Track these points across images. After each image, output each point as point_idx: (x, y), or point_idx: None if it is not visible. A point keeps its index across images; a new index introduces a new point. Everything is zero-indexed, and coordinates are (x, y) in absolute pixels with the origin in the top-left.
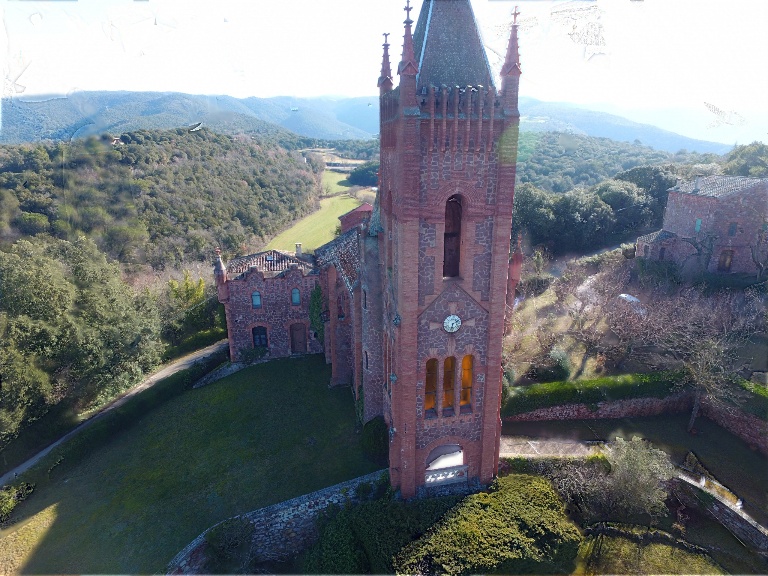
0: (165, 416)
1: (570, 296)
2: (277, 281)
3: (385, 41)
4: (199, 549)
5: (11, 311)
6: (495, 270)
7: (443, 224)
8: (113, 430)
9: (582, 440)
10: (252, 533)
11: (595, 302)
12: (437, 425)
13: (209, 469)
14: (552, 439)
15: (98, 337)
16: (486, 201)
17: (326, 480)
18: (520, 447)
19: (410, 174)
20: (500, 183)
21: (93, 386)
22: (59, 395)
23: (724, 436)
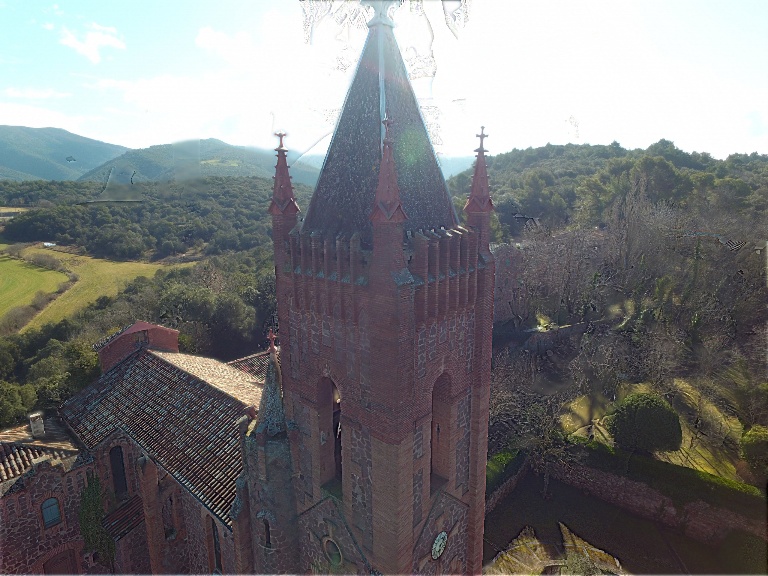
0: None
1: None
2: (8, 501)
3: (280, 145)
4: None
5: None
6: (478, 453)
7: (430, 420)
8: None
9: (489, 561)
10: None
11: None
12: None
13: None
14: None
15: None
16: (465, 371)
17: None
18: None
19: (404, 371)
20: (482, 346)
21: None
22: None
23: (565, 490)
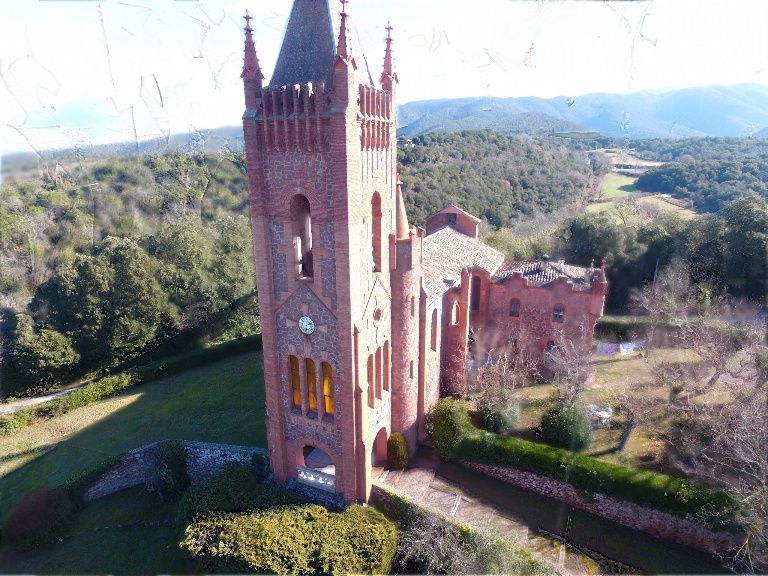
0: (240, 360)
1: (736, 359)
2: None
3: None
4: (151, 451)
5: (170, 260)
6: (337, 278)
7: (290, 223)
8: (206, 359)
9: (536, 525)
10: (186, 457)
11: (735, 372)
12: (303, 423)
13: (215, 404)
14: (496, 506)
15: (220, 290)
16: (328, 203)
17: (256, 443)
18: (441, 495)
19: (252, 173)
20: (333, 185)
21: (225, 326)
22: (182, 324)
23: None
